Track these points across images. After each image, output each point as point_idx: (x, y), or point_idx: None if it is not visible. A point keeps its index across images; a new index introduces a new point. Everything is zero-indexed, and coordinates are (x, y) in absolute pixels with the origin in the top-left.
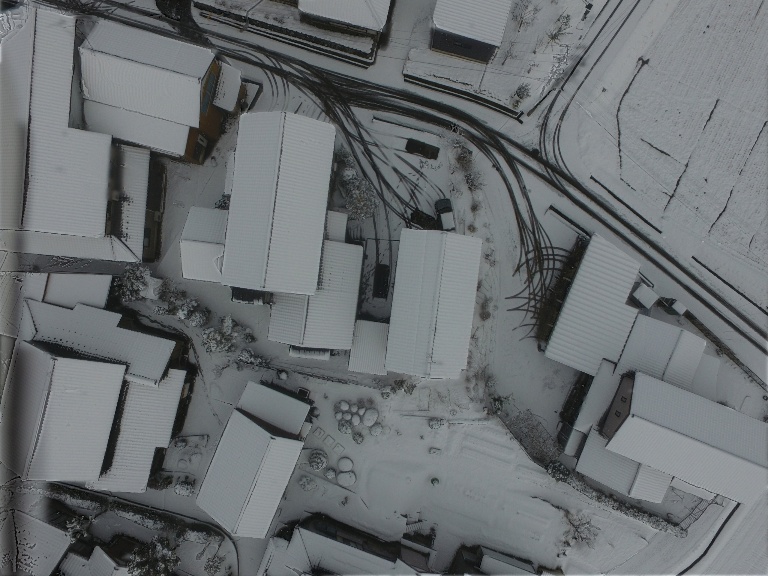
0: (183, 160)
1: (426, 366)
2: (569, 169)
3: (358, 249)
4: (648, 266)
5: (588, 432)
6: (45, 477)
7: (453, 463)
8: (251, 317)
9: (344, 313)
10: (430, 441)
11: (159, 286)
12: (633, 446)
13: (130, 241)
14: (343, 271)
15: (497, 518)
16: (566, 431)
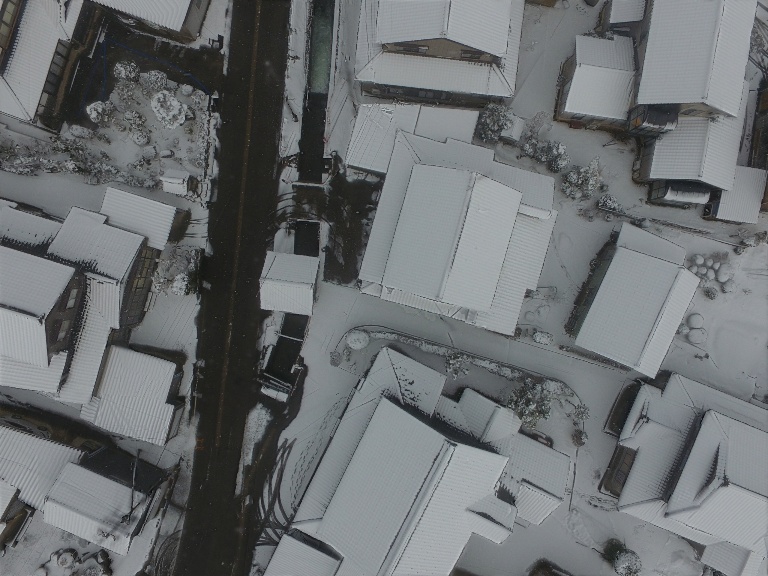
0: (534, 1)
1: None
2: None
3: (747, 84)
4: None
5: None
6: (454, 300)
7: None
8: None
9: (731, 151)
10: None
11: (530, 123)
12: None
13: (506, 73)
14: None
15: None
16: None
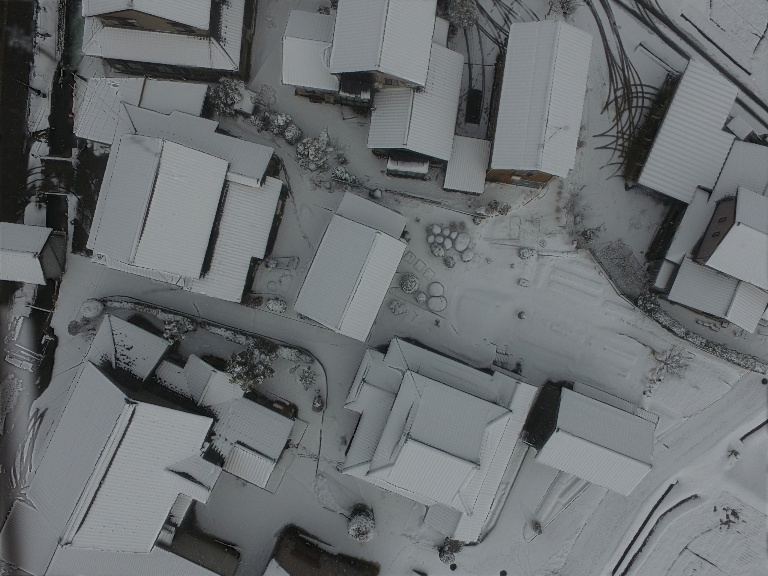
0: None
1: (538, 157)
2: (660, 5)
3: (460, 57)
4: (736, 109)
5: (681, 261)
6: (150, 265)
7: (541, 297)
8: (343, 139)
9: (445, 121)
10: (519, 272)
11: (256, 95)
12: (735, 260)
13: (228, 47)
14: (445, 77)
15: (584, 354)
16: (655, 267)
